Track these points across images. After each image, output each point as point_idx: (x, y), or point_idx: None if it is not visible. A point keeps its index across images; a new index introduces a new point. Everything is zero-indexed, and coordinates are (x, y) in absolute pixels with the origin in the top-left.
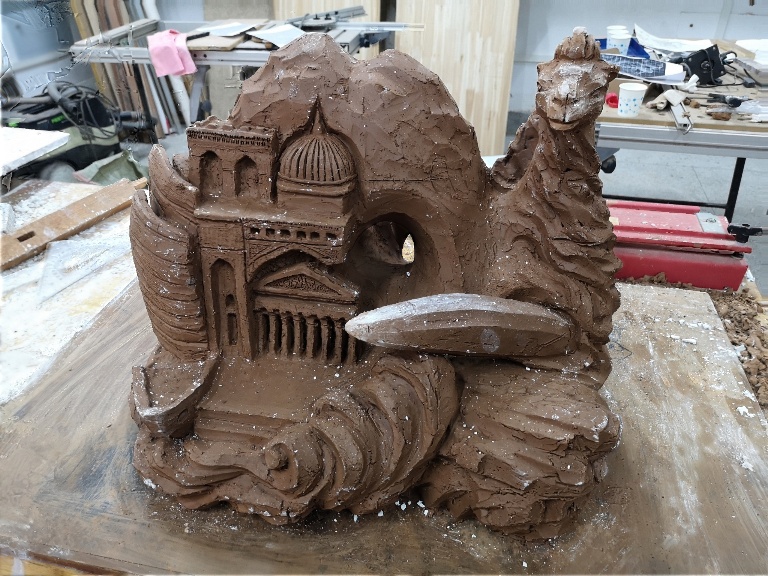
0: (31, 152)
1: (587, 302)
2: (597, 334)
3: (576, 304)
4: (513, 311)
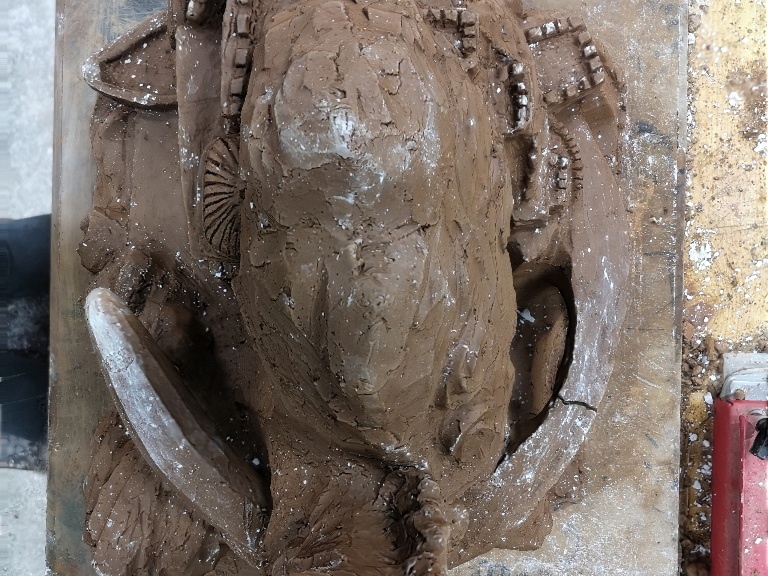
0: None
1: None
2: None
3: (268, 568)
4: (183, 489)
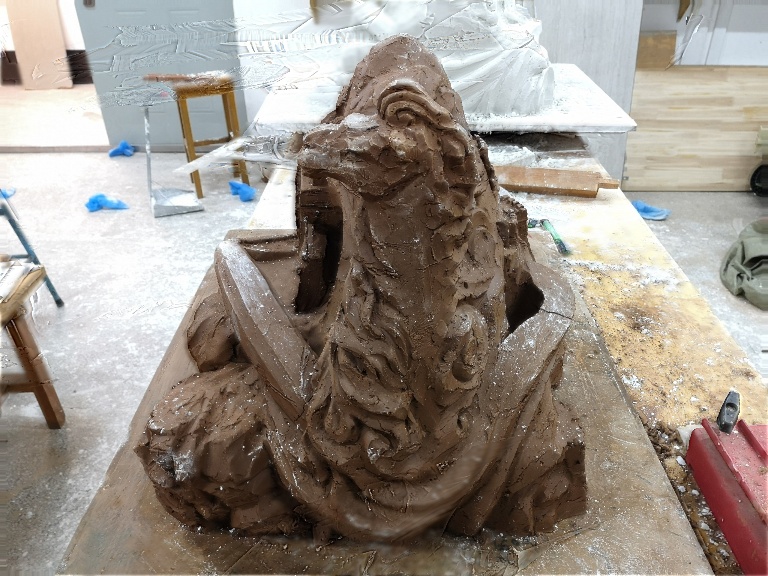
0: (582, 125)
1: (318, 397)
2: (311, 439)
3: (317, 390)
4: (259, 323)
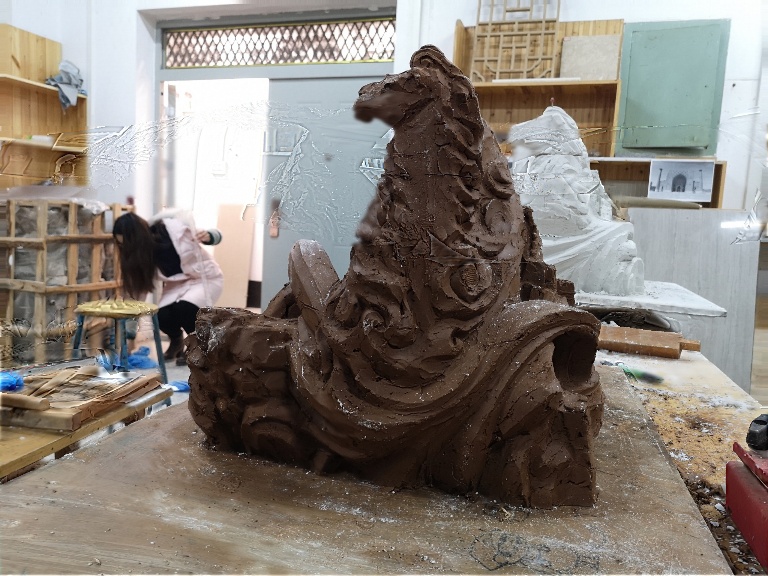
0: (671, 305)
1: None
2: (323, 327)
3: None
4: (308, 261)
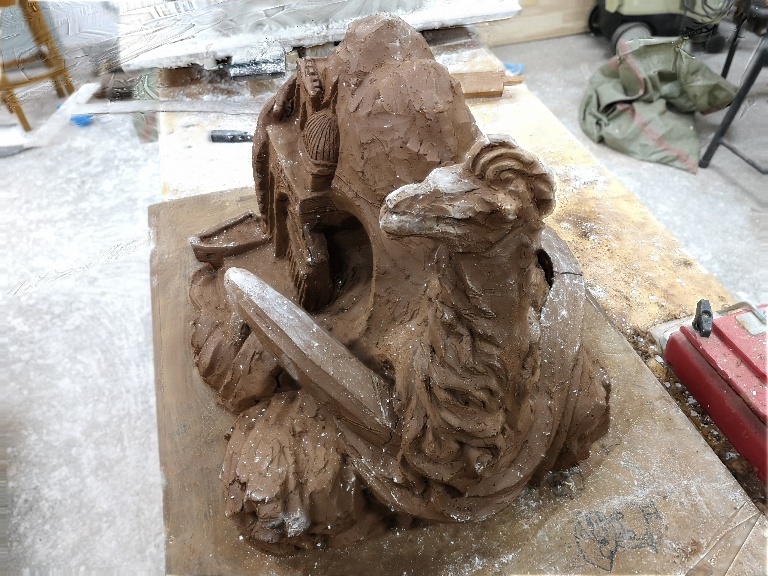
0: (470, 16)
1: (413, 427)
2: (411, 465)
3: (407, 420)
4: (322, 364)
